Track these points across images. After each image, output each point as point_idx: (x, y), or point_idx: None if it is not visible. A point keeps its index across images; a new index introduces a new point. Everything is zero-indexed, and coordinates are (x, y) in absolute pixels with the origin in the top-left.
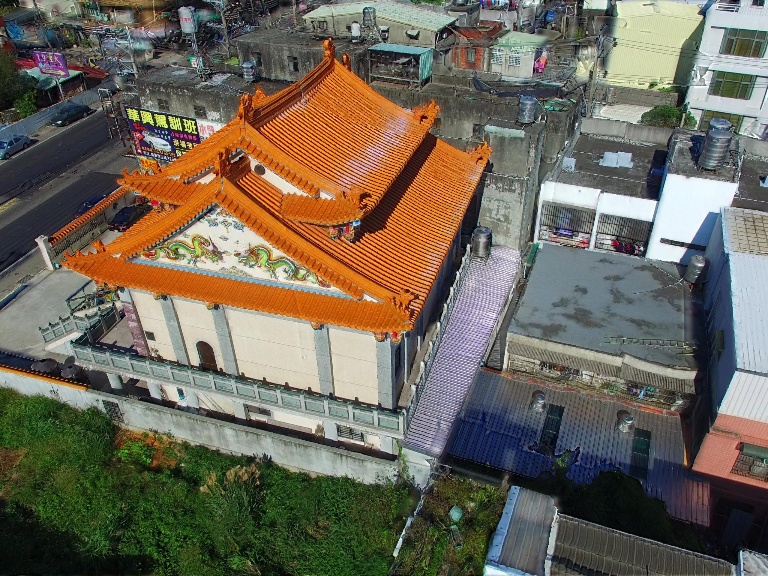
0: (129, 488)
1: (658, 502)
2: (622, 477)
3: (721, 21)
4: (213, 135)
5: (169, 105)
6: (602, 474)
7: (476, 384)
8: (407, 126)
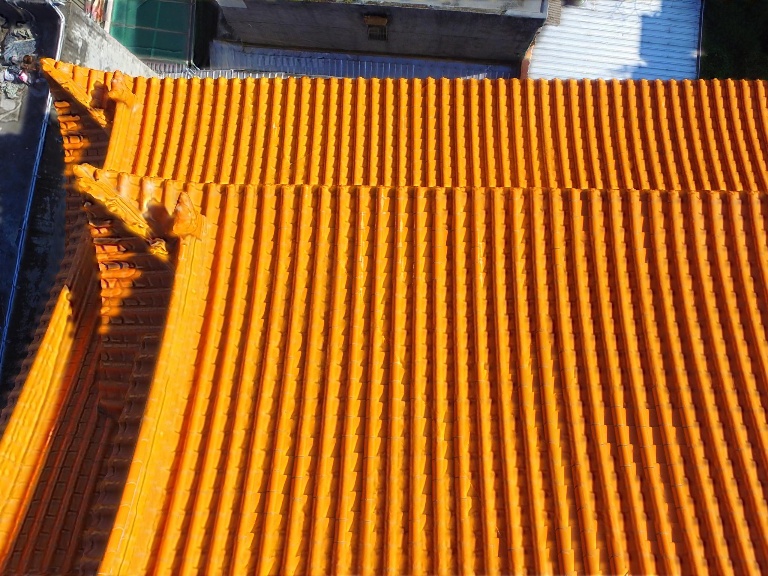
0: None
1: None
2: None
3: None
4: None
5: None
6: None
7: None
8: (249, 253)
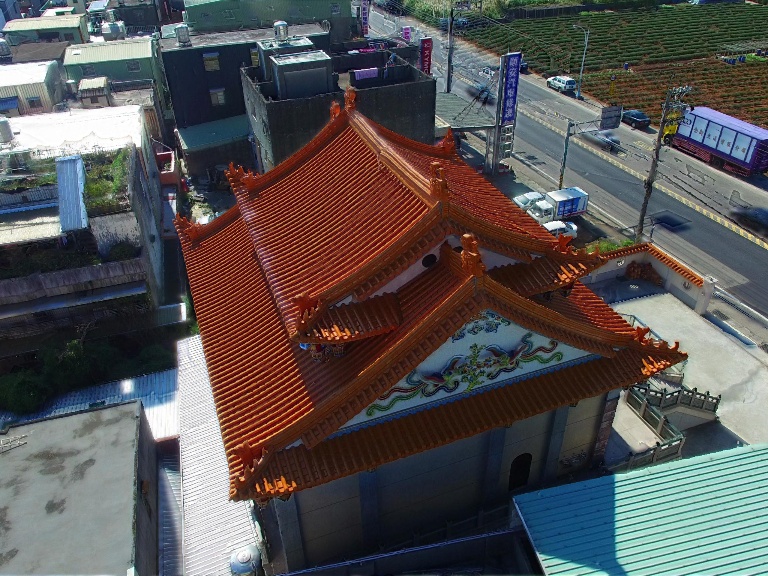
0: None
1: None
2: (26, 385)
3: None
4: (514, 205)
5: None
6: None
7: (179, 419)
8: None
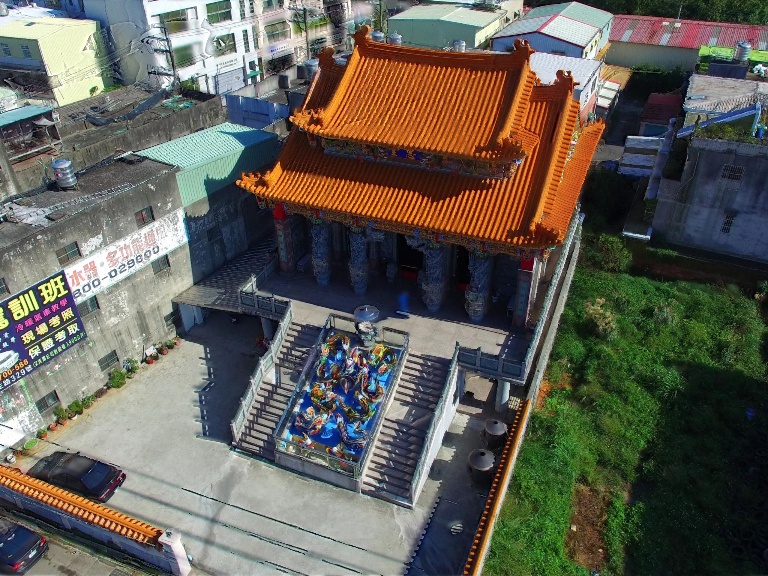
0: (610, 382)
1: None
2: None
3: (156, 10)
4: (390, 140)
5: (8, 283)
6: None
7: None
8: None
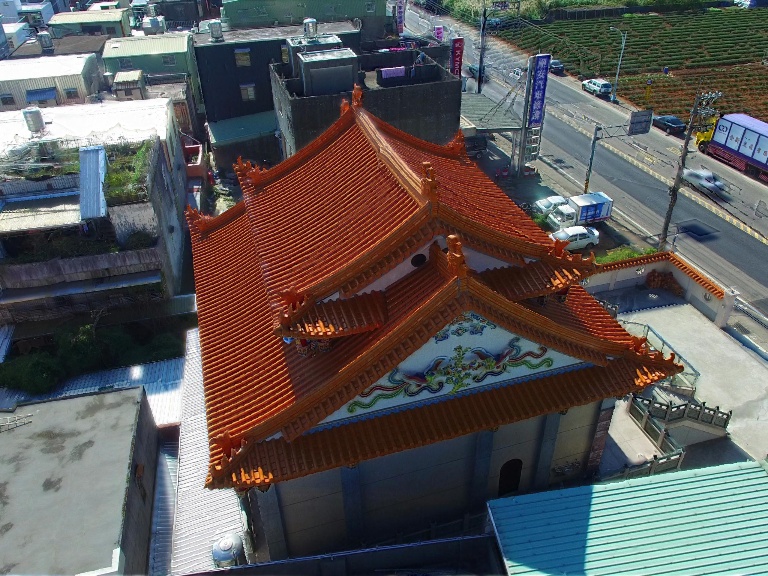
0: None
1: (13, 375)
2: (40, 366)
3: None
4: None
5: None
6: (56, 366)
7: None
8: None
